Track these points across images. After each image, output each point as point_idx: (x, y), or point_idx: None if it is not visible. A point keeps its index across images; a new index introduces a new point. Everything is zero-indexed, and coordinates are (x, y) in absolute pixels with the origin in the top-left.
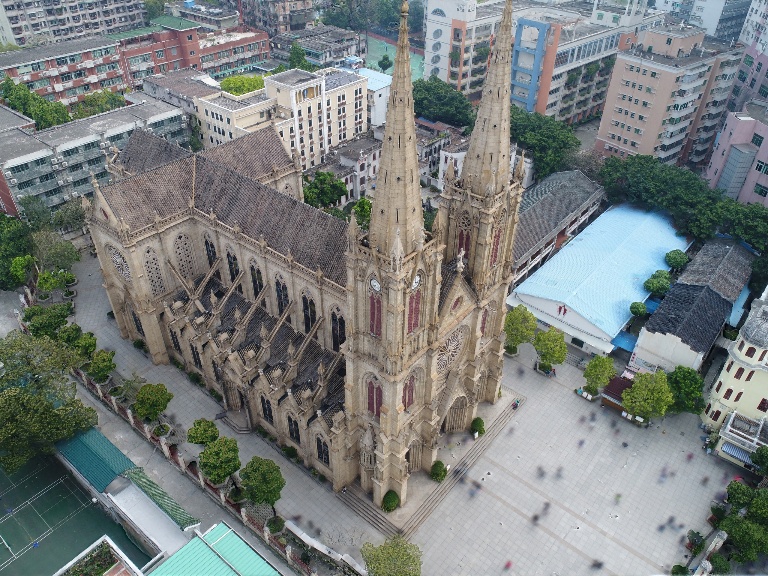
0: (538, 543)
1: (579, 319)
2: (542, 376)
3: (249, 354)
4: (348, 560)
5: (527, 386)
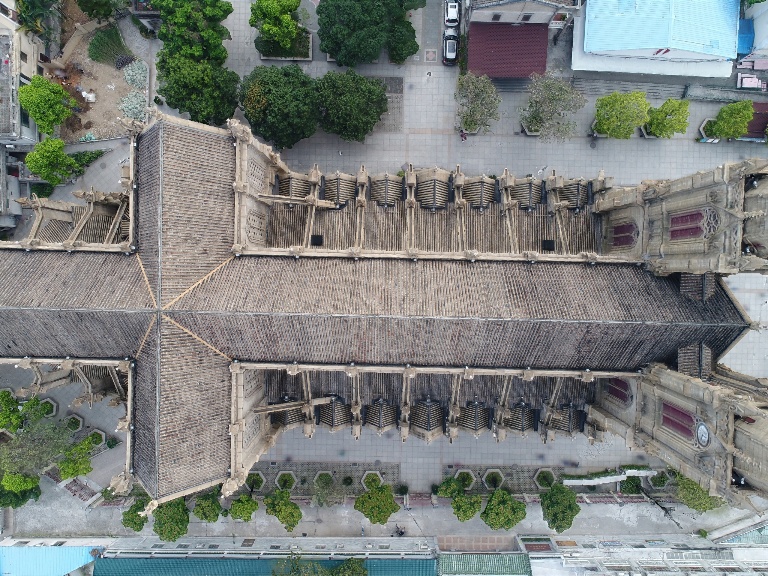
0: (743, 340)
1: (687, 53)
2: (653, 141)
3: (455, 435)
4: (632, 474)
5: (647, 168)
